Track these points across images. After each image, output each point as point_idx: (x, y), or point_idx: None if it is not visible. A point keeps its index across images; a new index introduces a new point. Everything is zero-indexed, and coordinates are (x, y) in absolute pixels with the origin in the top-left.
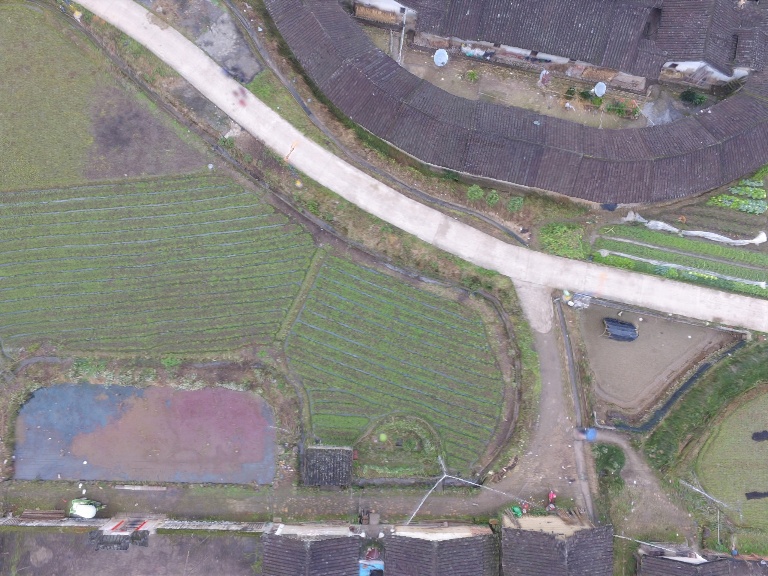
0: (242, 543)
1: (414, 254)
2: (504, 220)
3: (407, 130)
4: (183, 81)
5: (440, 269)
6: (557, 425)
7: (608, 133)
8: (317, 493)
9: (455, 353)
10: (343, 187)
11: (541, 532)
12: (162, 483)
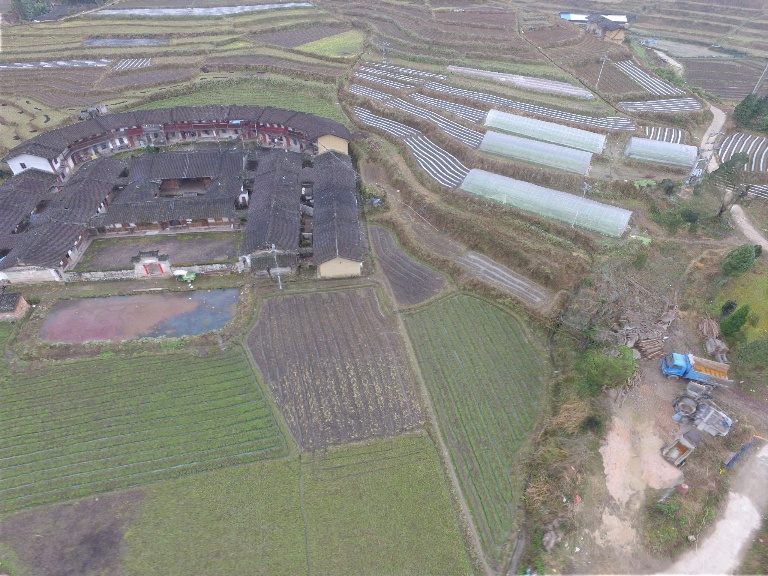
0: None
1: None
2: None
3: None
4: None
5: None
6: None
7: None
8: (27, 297)
9: None
10: None
11: None
12: (137, 294)
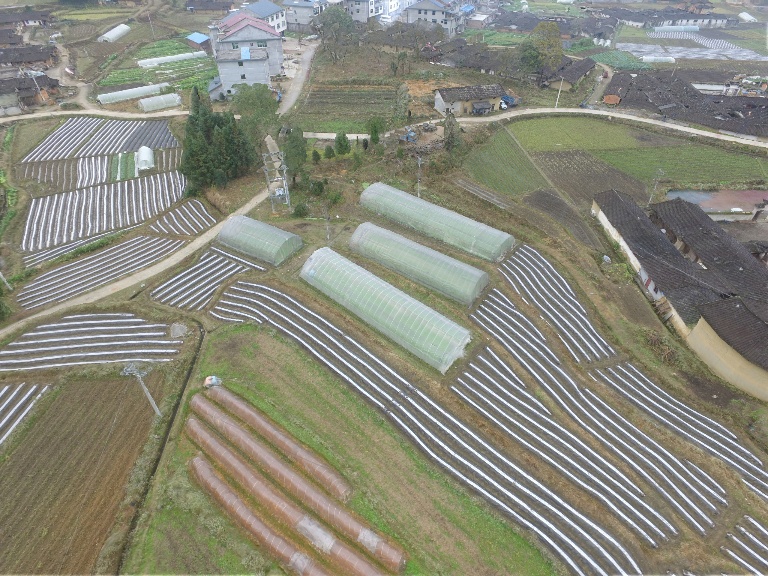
0: None
1: None
2: None
3: (766, 131)
4: None
5: None
6: None
7: None
8: None
9: None
10: None
11: None
12: None
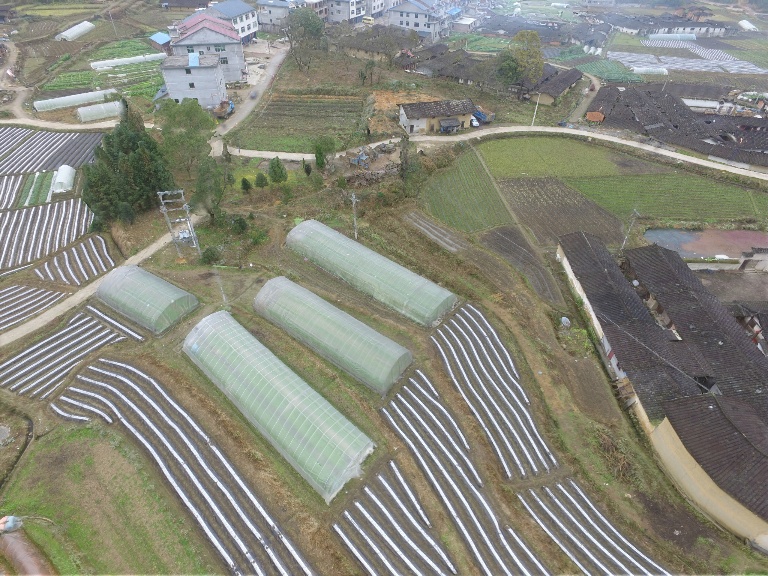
0: None
1: None
2: None
3: (759, 159)
4: (647, 151)
5: None
6: None
7: None
8: None
9: None
10: None
11: None
12: None
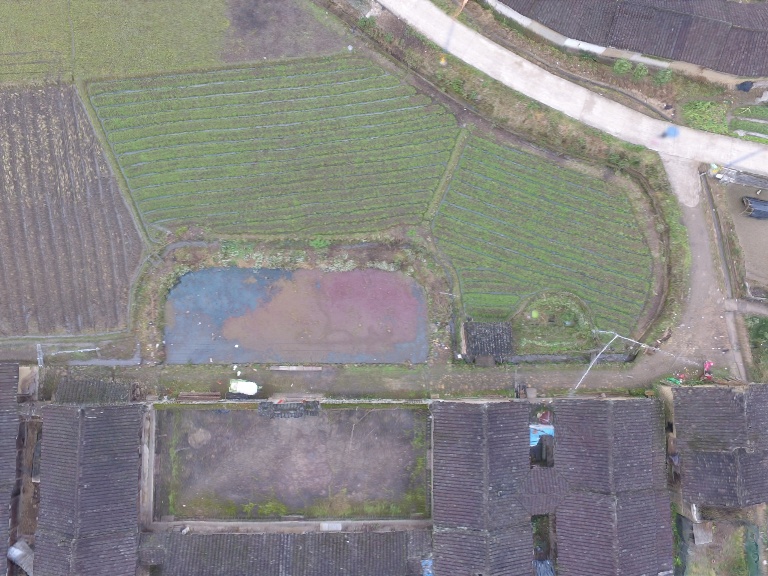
0: (400, 420)
1: (561, 130)
2: (647, 97)
3: (553, 4)
4: None
5: (588, 145)
6: (708, 297)
7: (750, 7)
8: (472, 369)
9: (602, 230)
10: (488, 64)
11: (716, 387)
12: (316, 364)
